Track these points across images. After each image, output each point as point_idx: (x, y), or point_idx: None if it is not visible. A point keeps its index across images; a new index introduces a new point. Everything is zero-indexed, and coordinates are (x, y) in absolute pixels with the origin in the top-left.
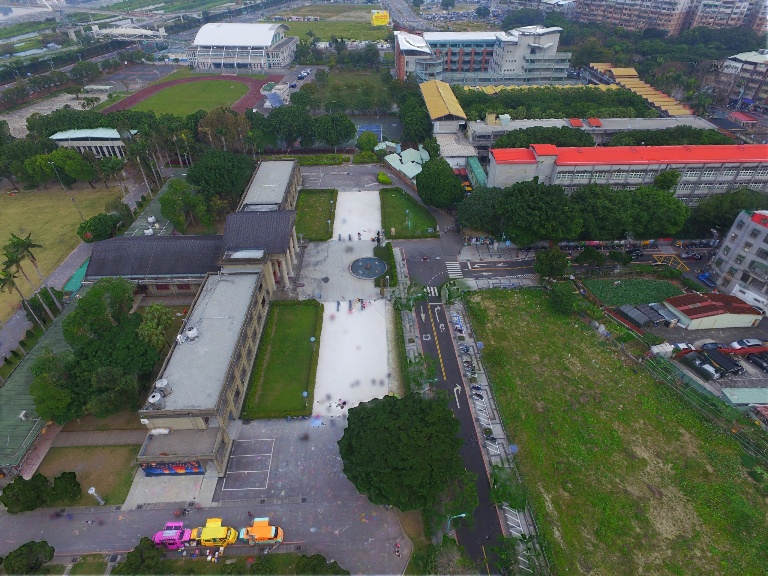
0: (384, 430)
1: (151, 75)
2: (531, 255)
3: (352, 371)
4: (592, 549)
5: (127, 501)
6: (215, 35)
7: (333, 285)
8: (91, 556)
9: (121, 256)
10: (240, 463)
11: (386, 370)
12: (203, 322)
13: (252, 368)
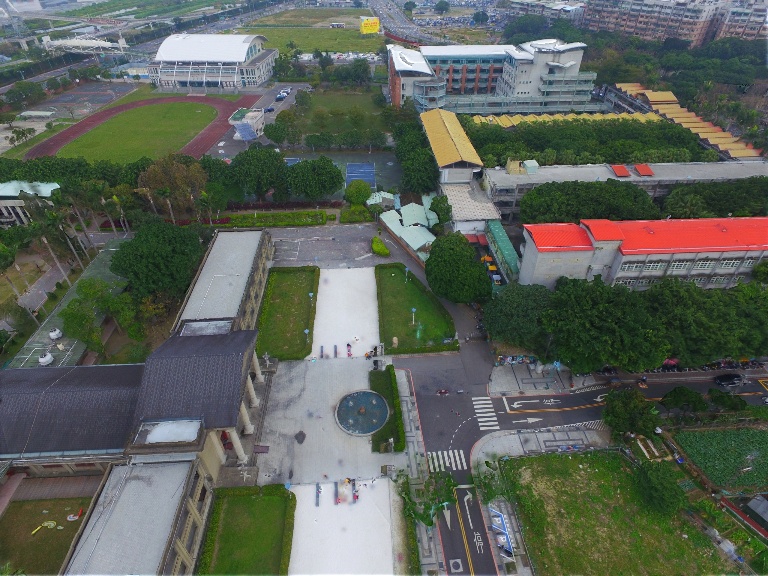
0: None
1: (105, 96)
2: (590, 382)
3: None
4: None
5: None
6: (180, 49)
7: (311, 448)
8: None
9: None
10: None
11: None
12: None
13: None
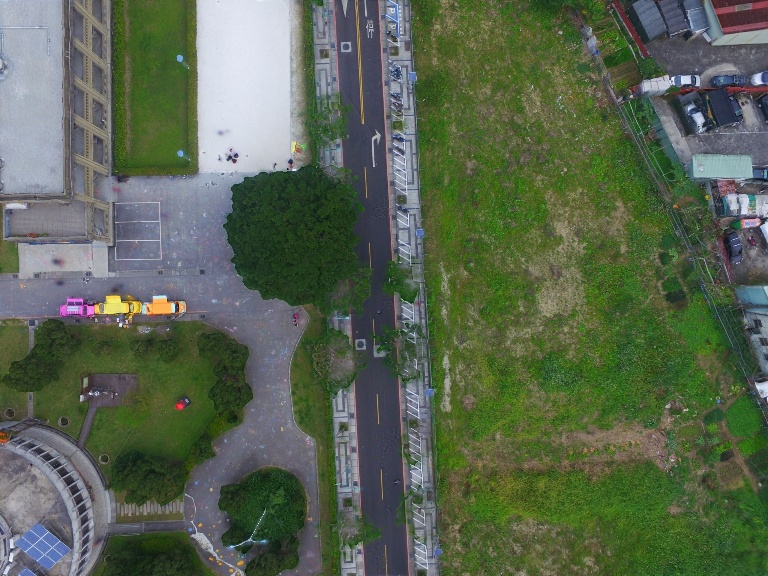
0: (270, 224)
1: None
2: None
3: (244, 105)
4: (472, 325)
5: (21, 270)
6: None
7: None
8: (9, 321)
9: None
10: (127, 231)
11: (288, 105)
12: (4, 36)
13: (111, 97)
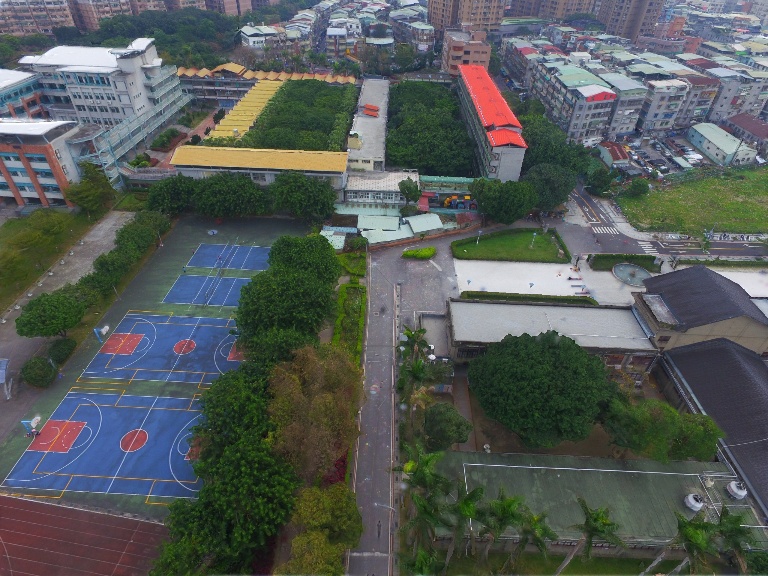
0: None
1: None
2: None
3: None
4: None
5: None
6: None
7: None
8: None
9: None
10: None
11: (759, 274)
12: None
13: None
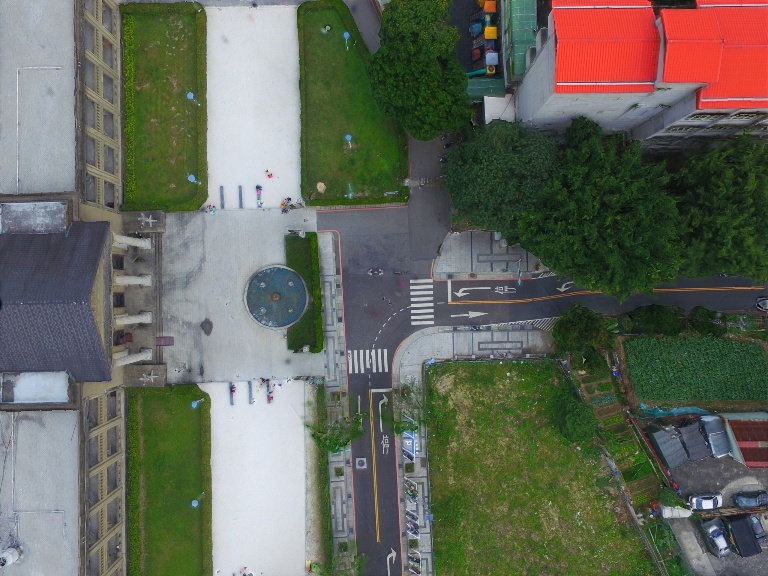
0: None
1: None
2: None
3: (259, 522)
4: None
5: None
6: None
7: (220, 342)
8: None
9: None
10: None
11: (303, 523)
12: (20, 520)
13: (125, 517)
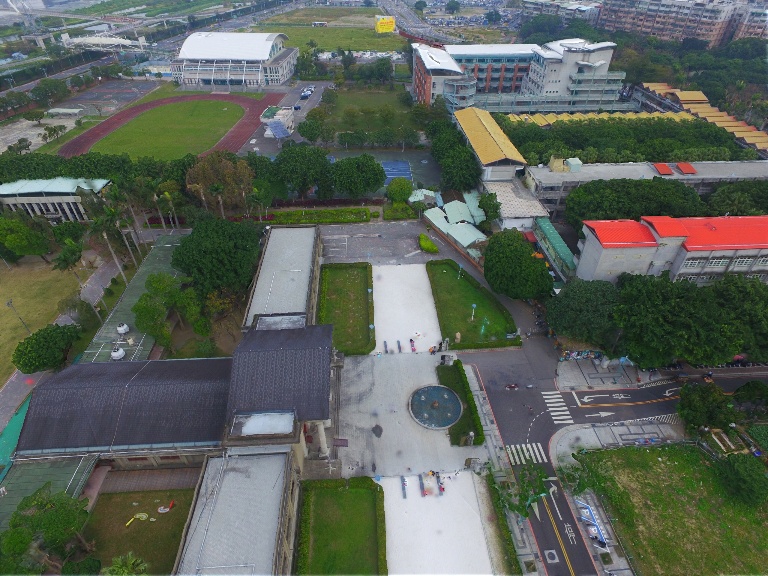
0: None
1: (129, 93)
2: (656, 377)
3: None
4: None
5: None
6: (203, 47)
7: (390, 442)
8: None
9: (73, 413)
10: None
11: None
12: None
13: None
